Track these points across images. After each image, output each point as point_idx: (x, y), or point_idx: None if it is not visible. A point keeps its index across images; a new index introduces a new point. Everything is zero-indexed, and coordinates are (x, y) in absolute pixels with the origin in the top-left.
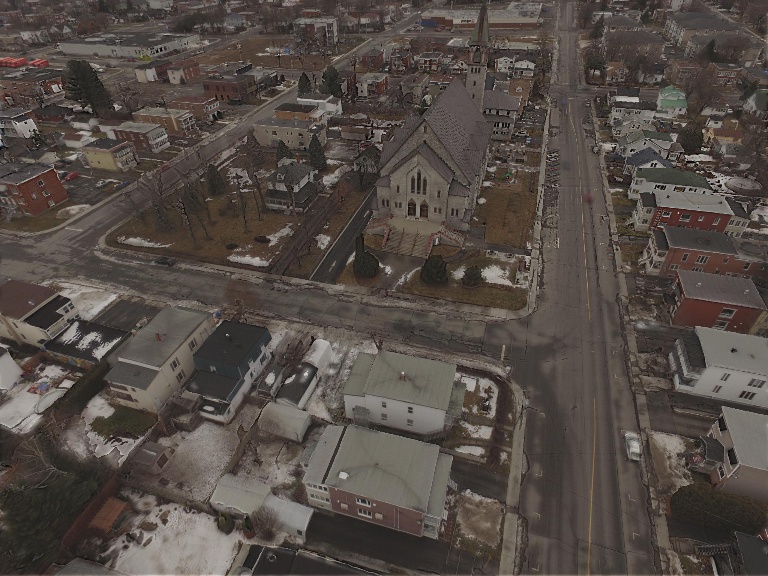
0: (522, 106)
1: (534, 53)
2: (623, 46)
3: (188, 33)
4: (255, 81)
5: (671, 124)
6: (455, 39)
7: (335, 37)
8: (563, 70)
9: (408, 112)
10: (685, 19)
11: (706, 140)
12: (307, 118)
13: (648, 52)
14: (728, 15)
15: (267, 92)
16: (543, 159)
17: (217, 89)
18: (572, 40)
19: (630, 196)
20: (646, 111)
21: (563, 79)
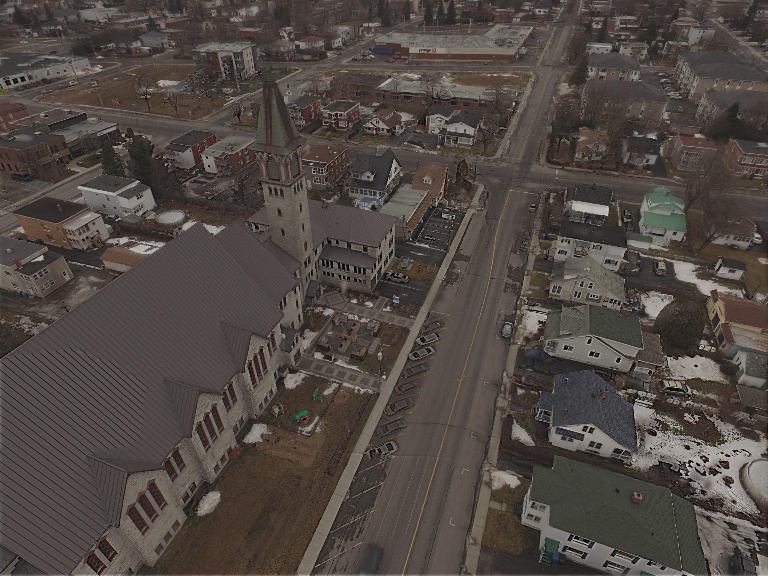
0: (422, 213)
1: (488, 104)
2: (608, 102)
3: (77, 56)
4: (66, 143)
5: (655, 266)
6: (405, 74)
7: (249, 68)
8: (522, 133)
9: (251, 211)
10: (701, 61)
11: (711, 316)
12: (60, 229)
13: (636, 122)
14: (760, 55)
15: (88, 157)
16: (404, 351)
17: (0, 156)
18: (552, 82)
19: (524, 520)
20: (611, 246)
21: (516, 150)
